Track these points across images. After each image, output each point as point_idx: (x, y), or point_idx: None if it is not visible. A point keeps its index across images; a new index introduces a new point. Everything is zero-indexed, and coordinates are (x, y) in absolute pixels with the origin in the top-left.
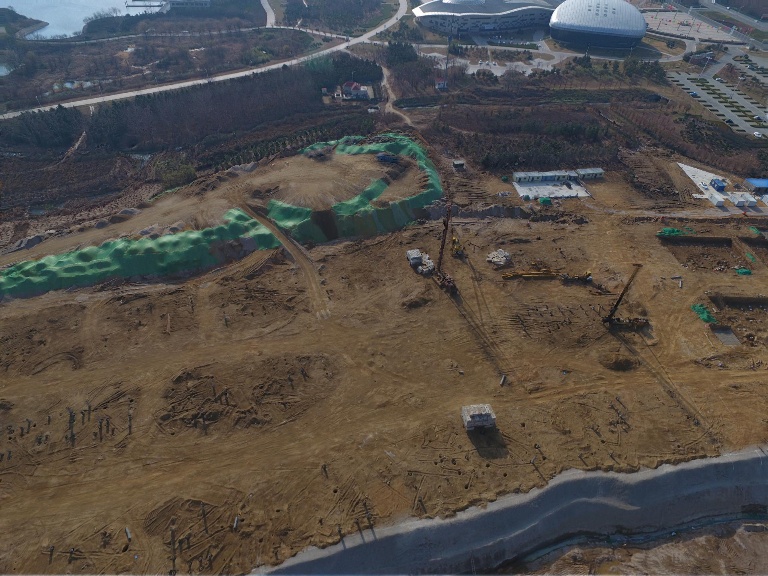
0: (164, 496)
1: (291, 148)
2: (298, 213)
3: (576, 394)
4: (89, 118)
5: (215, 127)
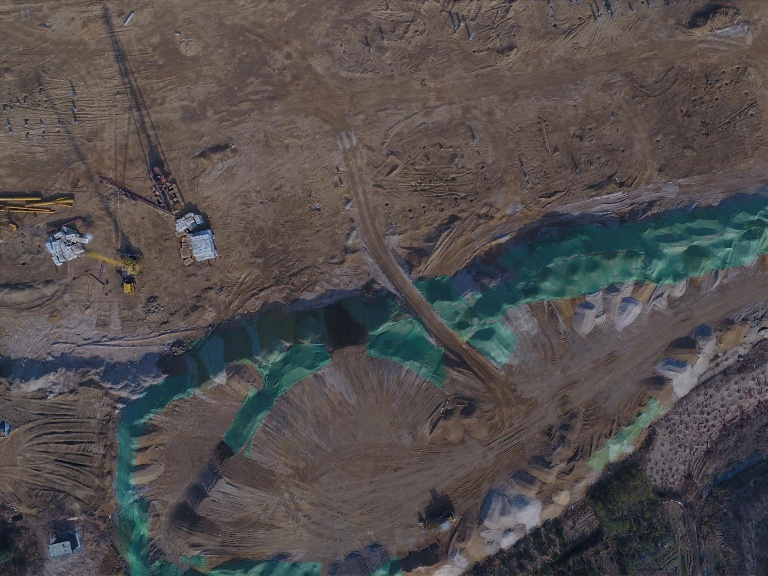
0: None
1: None
2: (391, 347)
3: None
4: None
5: None
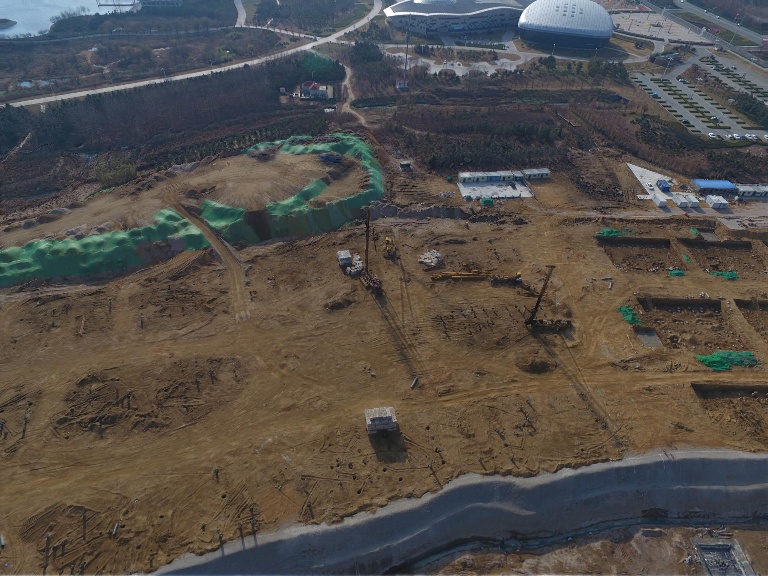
0: (46, 502)
1: (238, 148)
2: (231, 213)
3: (487, 397)
4: (34, 117)
5: (166, 126)
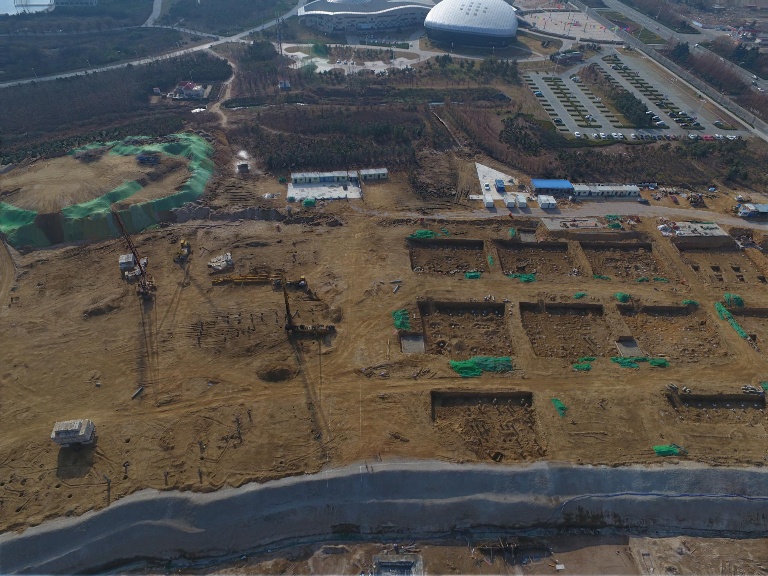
0: None
1: None
2: (23, 216)
3: (207, 407)
4: None
5: (17, 127)
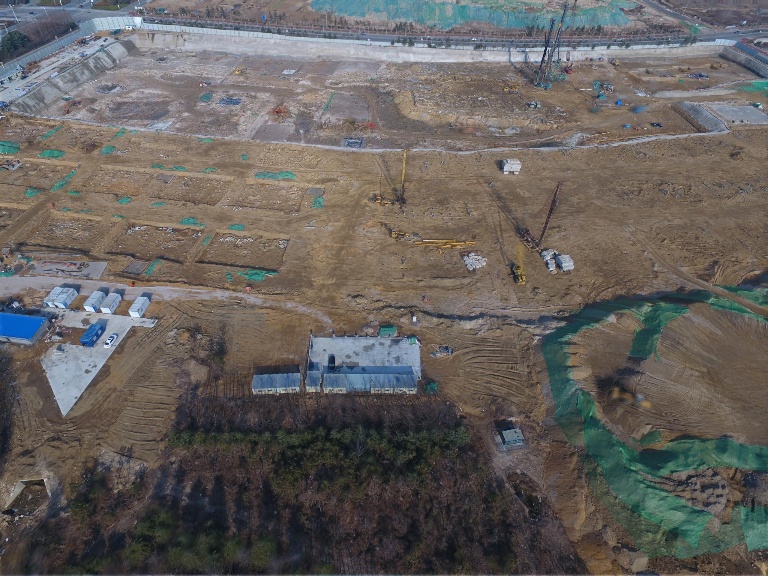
0: (661, 164)
1: None
2: (726, 307)
3: (447, 175)
4: None
5: None
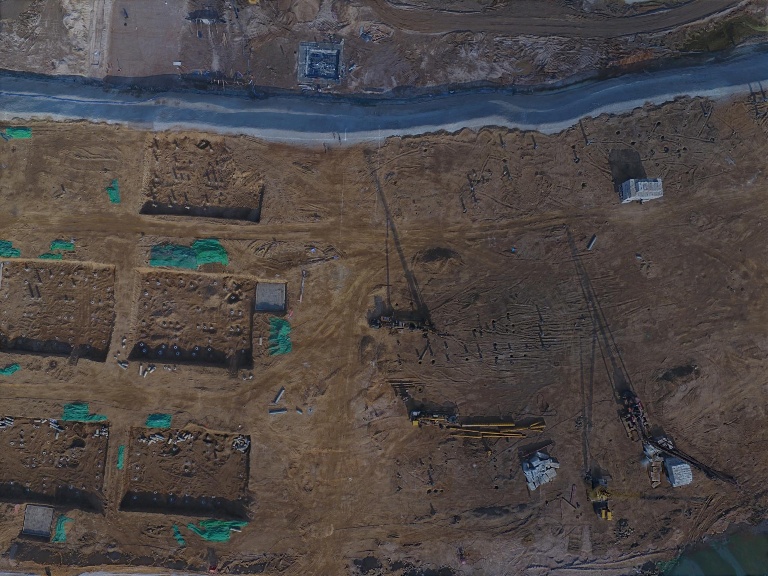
0: None
1: None
2: None
3: (511, 220)
4: None
5: None
